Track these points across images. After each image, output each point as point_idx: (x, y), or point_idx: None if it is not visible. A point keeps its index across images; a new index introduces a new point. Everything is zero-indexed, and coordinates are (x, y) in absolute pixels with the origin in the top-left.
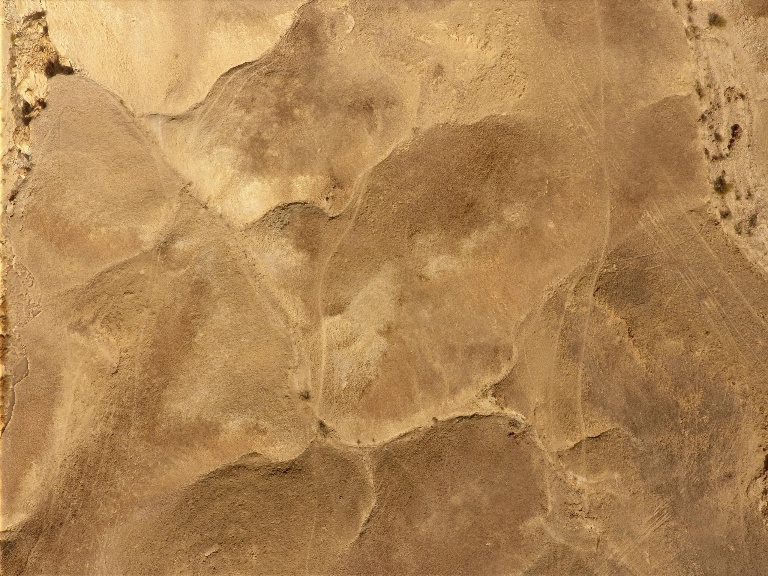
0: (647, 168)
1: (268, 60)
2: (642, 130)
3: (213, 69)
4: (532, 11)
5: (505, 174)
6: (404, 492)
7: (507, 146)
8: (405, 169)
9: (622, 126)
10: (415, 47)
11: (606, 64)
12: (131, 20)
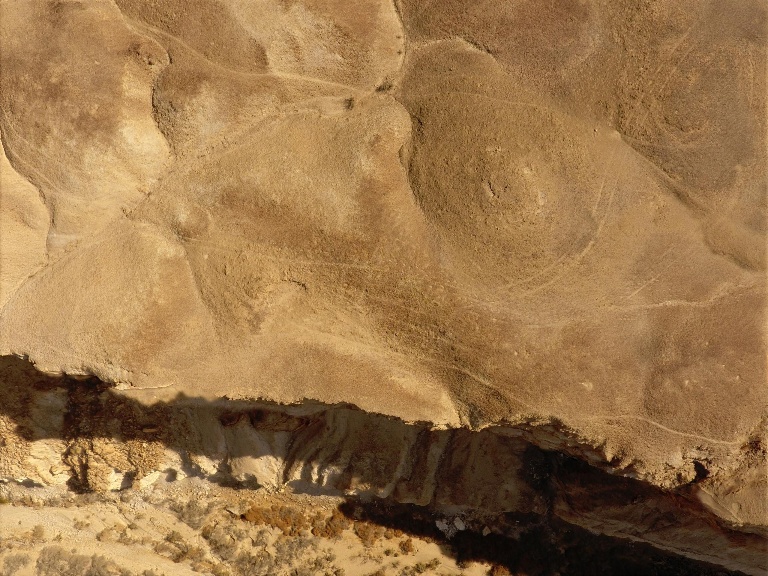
0: None
1: None
2: None
3: (4, 173)
4: None
5: None
6: (450, 6)
7: None
8: None
9: None
10: None
11: None
12: None
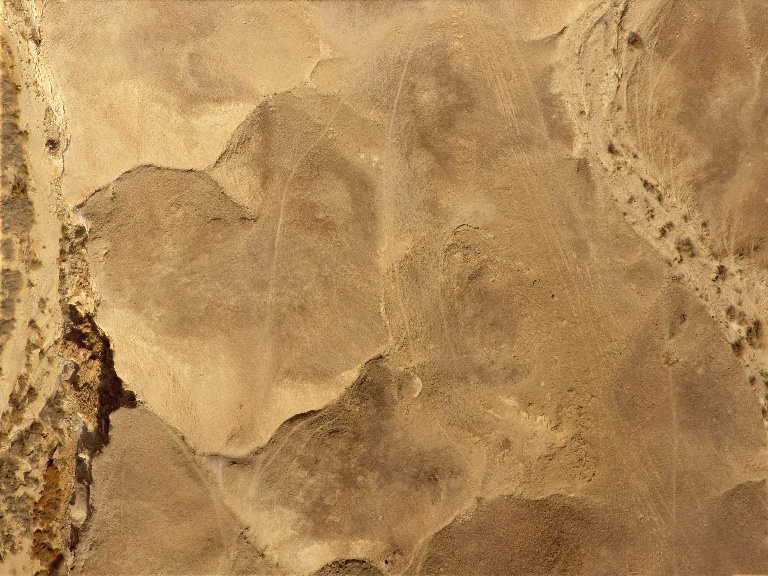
0: (718, 566)
1: (332, 413)
2: (714, 523)
3: (277, 417)
4: (605, 390)
5: (571, 566)
6: None
7: (574, 533)
8: (467, 541)
9: (694, 518)
10: (483, 419)
11: (679, 450)
12: (198, 374)
